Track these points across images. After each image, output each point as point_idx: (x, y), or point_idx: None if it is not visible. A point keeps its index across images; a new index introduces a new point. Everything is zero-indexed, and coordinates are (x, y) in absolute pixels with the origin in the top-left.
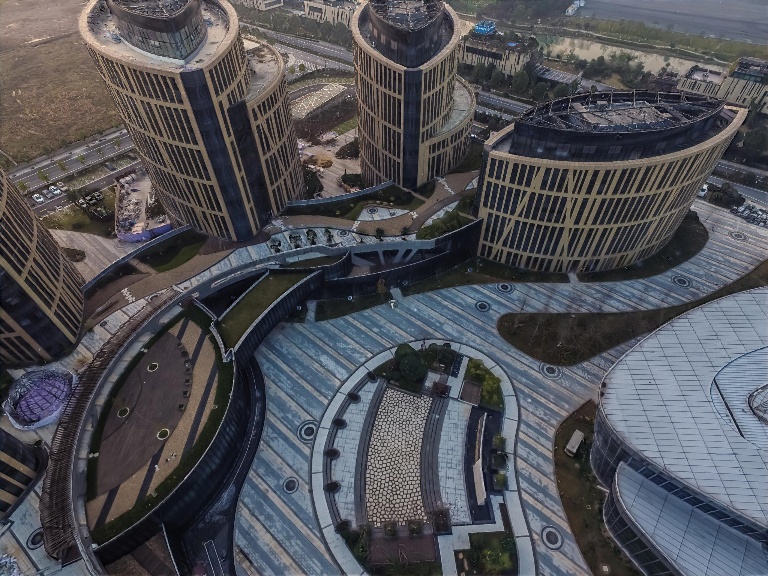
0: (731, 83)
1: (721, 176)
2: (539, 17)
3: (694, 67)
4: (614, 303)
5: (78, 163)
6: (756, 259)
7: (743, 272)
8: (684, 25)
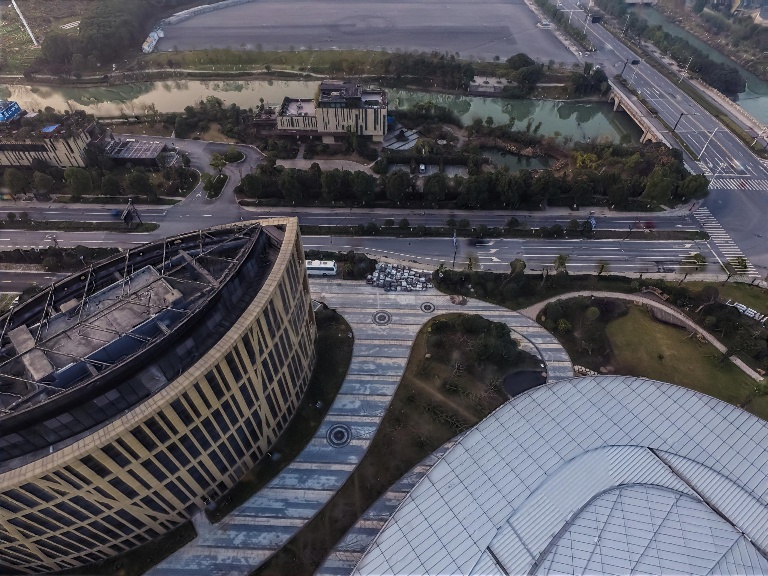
0: (322, 114)
1: (348, 234)
2: (112, 62)
3: (284, 101)
4: (264, 539)
5: None
6: (405, 346)
7: (398, 376)
8: (272, 42)
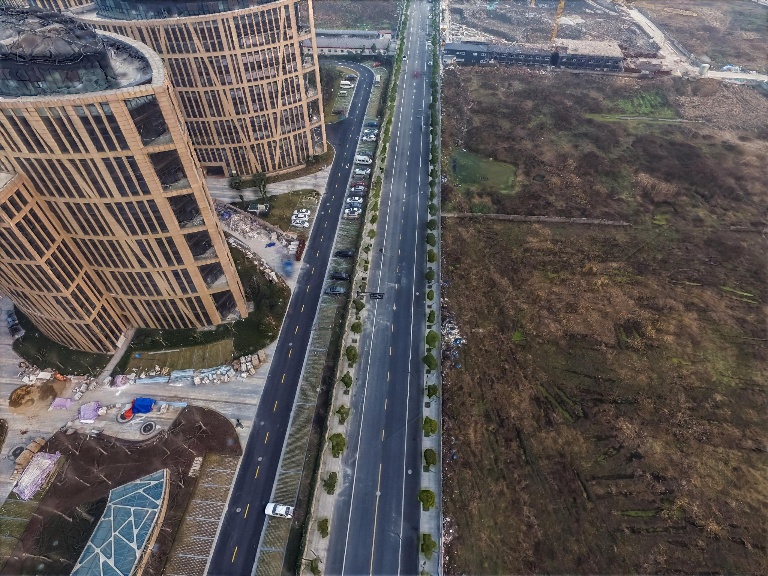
0: None
1: None
2: None
3: None
4: None
5: (397, 247)
6: None
7: None
8: None
